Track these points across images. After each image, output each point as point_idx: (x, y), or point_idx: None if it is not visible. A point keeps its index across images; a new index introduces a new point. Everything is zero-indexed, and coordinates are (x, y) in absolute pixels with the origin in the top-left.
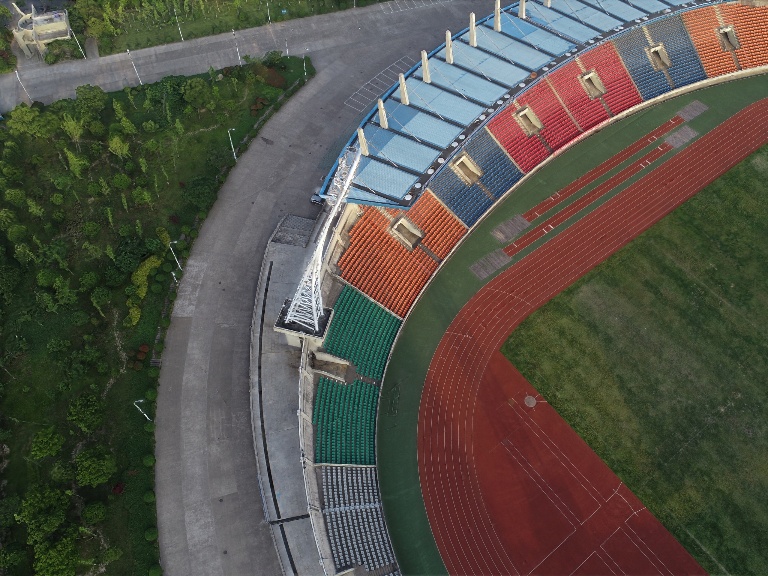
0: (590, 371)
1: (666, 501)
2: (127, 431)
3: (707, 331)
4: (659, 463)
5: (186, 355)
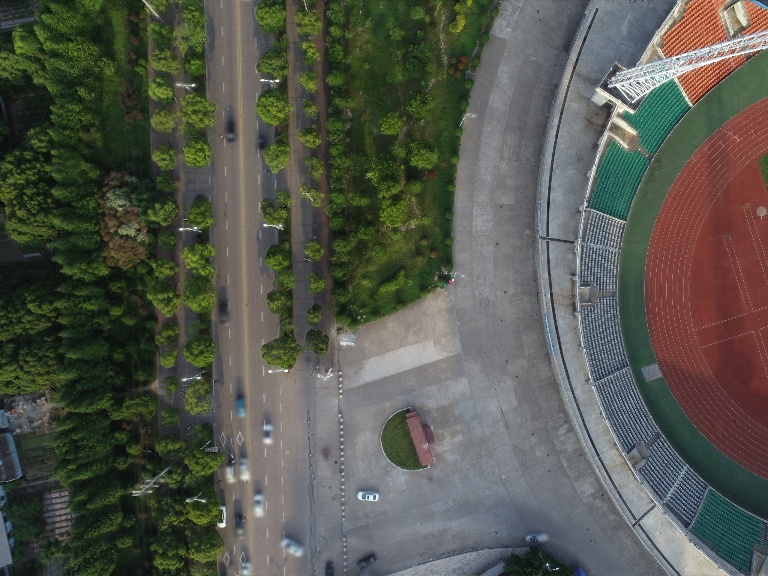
0: None
1: None
2: (441, 129)
3: None
4: None
5: (496, 76)
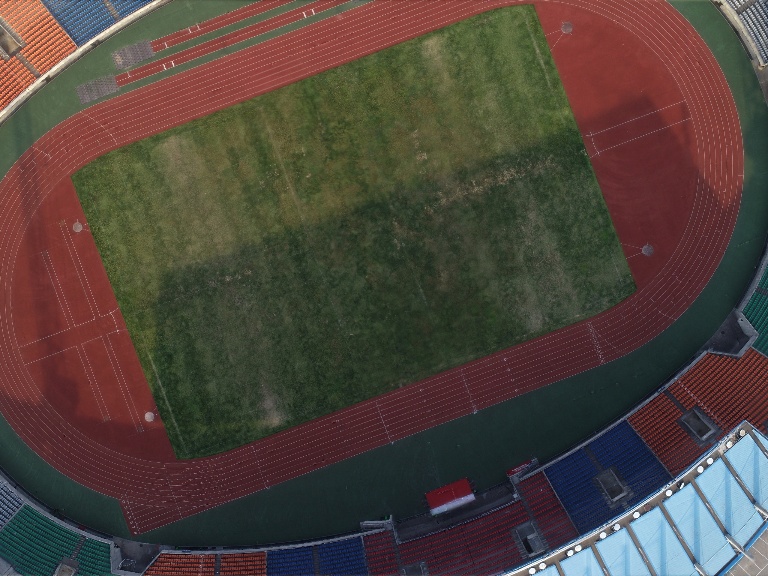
0: (138, 217)
1: (144, 330)
2: None
3: (257, 211)
4: (154, 303)
5: None
